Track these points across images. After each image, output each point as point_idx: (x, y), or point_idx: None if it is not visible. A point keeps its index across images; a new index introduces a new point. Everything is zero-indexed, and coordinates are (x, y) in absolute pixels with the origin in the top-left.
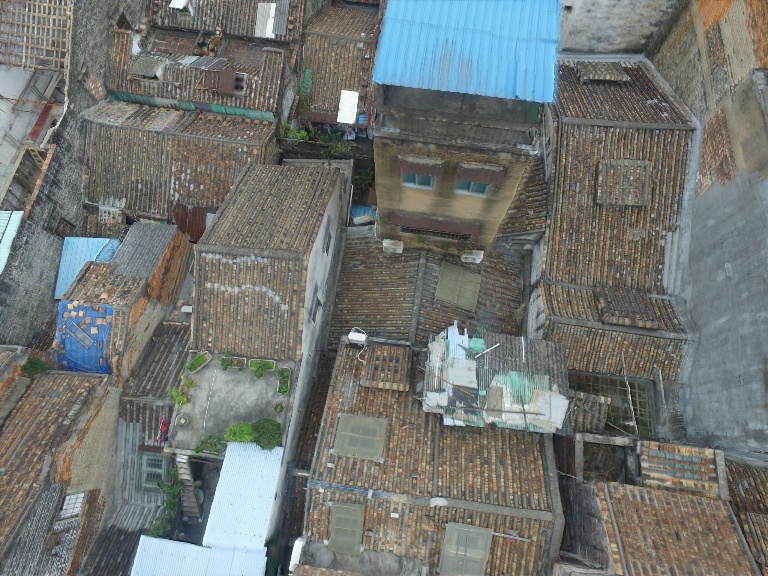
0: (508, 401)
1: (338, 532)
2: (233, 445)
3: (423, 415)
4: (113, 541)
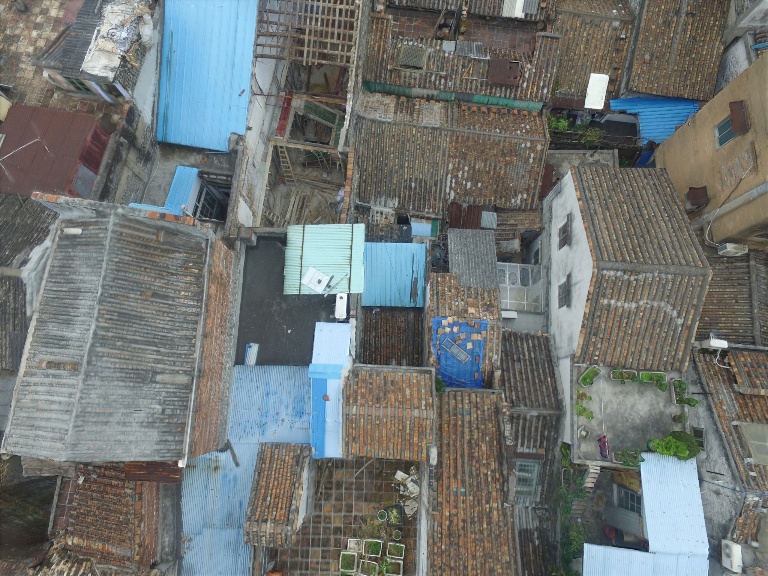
0: None
1: (762, 534)
2: (646, 456)
3: None
4: None
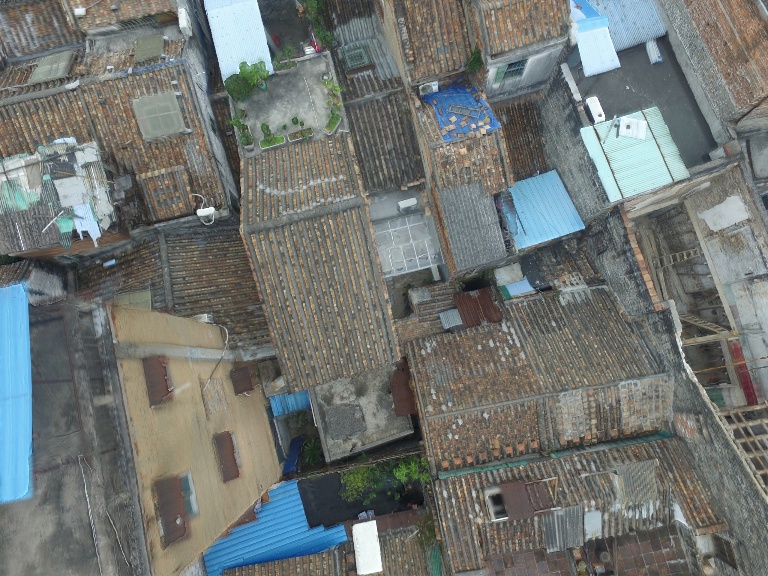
0: (22, 178)
1: None
2: None
3: (118, 160)
4: (362, 6)
